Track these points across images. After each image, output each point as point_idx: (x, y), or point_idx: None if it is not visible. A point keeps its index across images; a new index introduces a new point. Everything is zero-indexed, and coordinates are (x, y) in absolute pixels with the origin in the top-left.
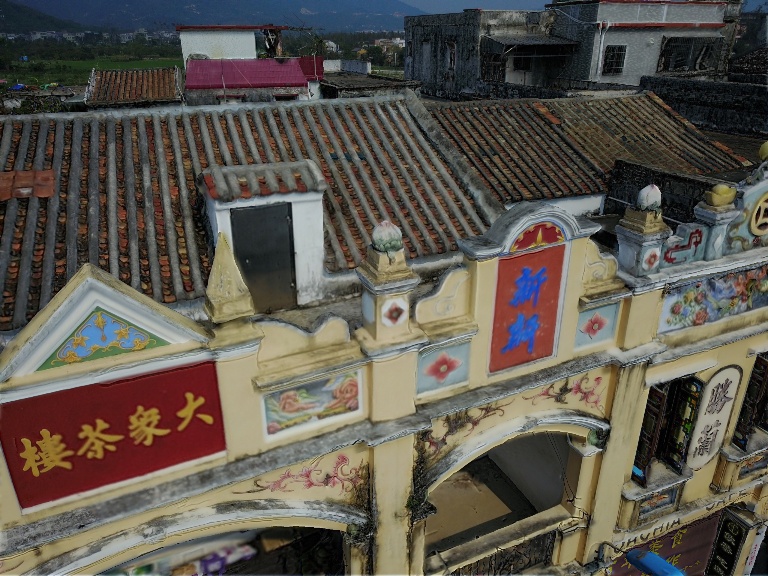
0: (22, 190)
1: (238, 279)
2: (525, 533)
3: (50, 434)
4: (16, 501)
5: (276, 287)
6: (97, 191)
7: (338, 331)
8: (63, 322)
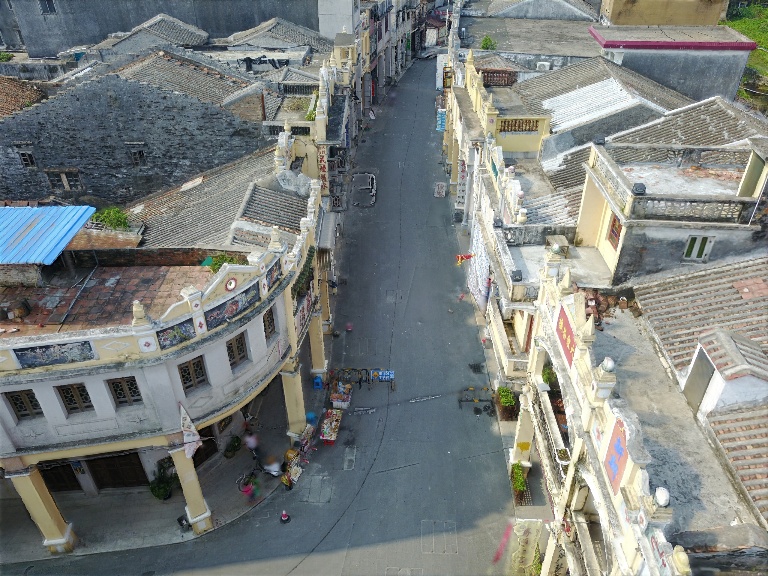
0: (746, 289)
1: (588, 329)
2: (589, 568)
3: None
4: None
5: (696, 398)
6: (757, 313)
7: None
8: None
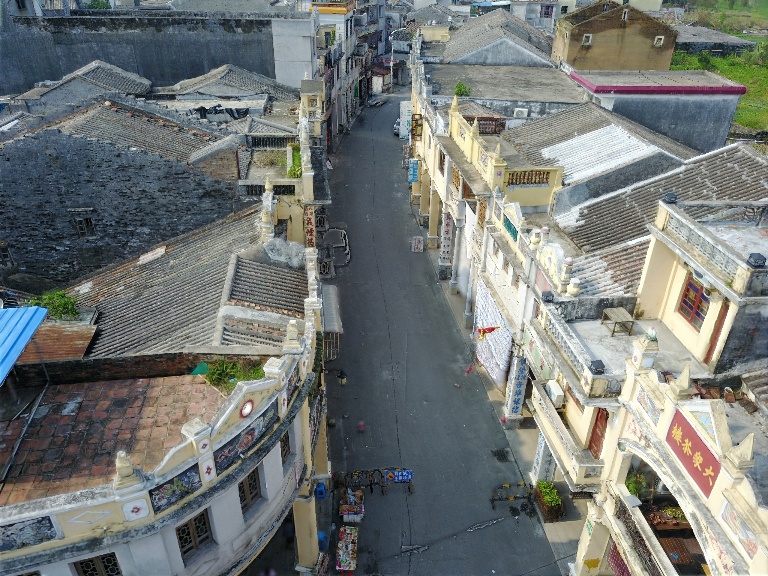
0: None
1: (746, 452)
2: None
3: (681, 430)
4: (666, 437)
5: None
6: None
7: (767, 520)
8: (700, 406)
